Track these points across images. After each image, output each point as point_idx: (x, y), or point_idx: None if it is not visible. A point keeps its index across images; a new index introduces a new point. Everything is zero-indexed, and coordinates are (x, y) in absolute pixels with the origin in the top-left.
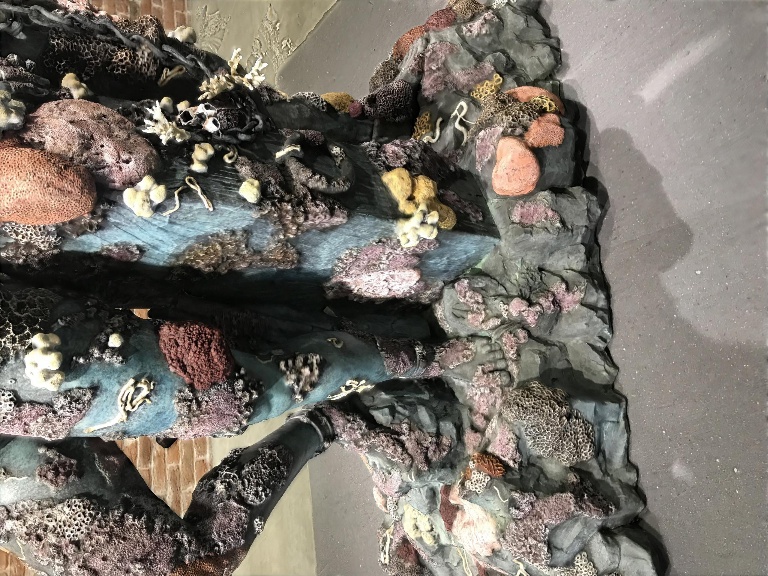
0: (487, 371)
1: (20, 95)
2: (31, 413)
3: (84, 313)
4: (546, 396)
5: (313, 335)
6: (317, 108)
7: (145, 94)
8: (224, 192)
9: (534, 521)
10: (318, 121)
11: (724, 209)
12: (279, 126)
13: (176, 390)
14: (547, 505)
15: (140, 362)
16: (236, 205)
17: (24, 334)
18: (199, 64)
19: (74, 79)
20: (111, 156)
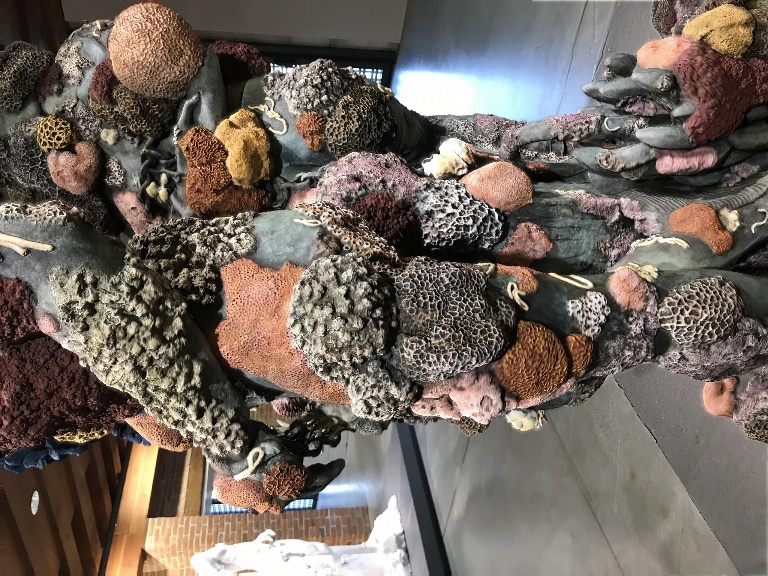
0: None
1: None
2: None
3: None
4: None
5: None
6: None
7: None
8: None
9: None
10: None
11: (723, 419)
12: None
13: None
14: None
15: None
16: None
17: None
18: None
19: None
20: None
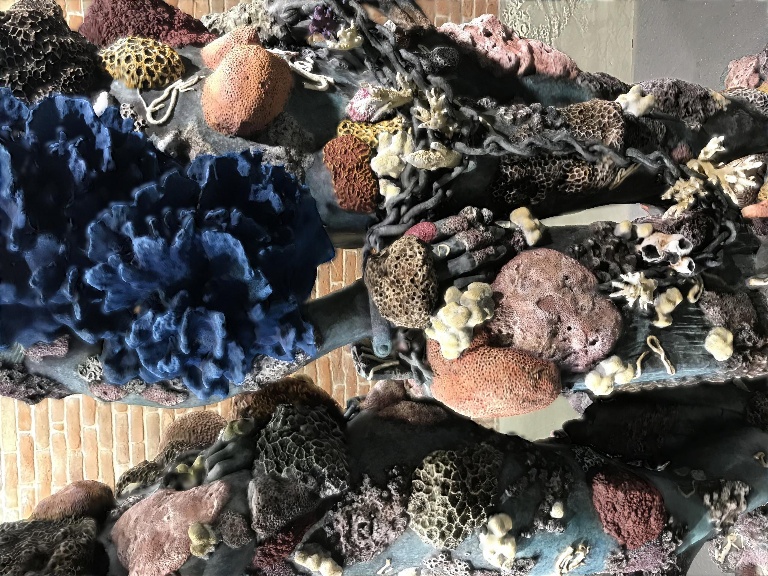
0: None
1: (482, 266)
2: (480, 575)
3: (526, 477)
4: None
5: (737, 448)
6: (763, 115)
7: (591, 199)
8: (688, 349)
9: None
10: (760, 132)
11: None
12: None
13: (609, 552)
14: None
15: (577, 527)
16: (701, 366)
17: (480, 515)
18: (665, 161)
19: (528, 218)
20: (579, 342)
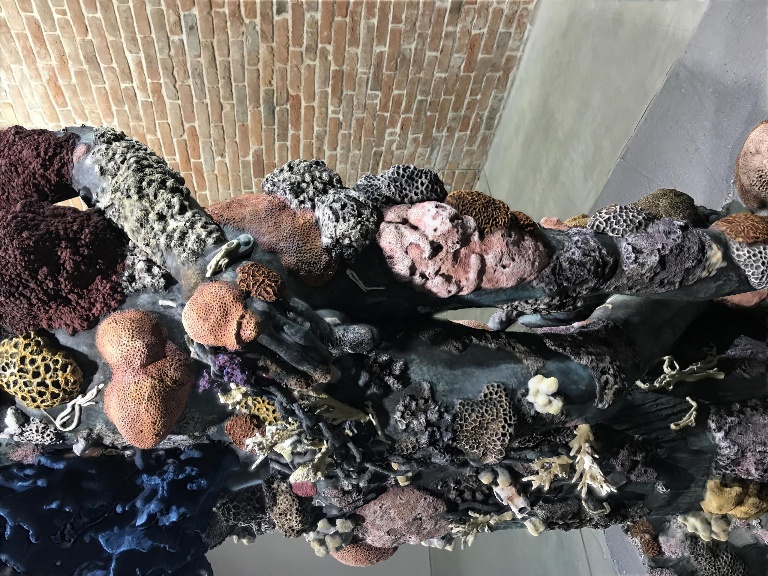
0: None
1: None
2: None
3: None
4: (723, 571)
5: None
6: None
7: None
8: None
9: (656, 569)
10: (741, 291)
11: None
12: None
13: None
14: (670, 575)
15: None
16: None
17: None
18: None
19: None
20: None
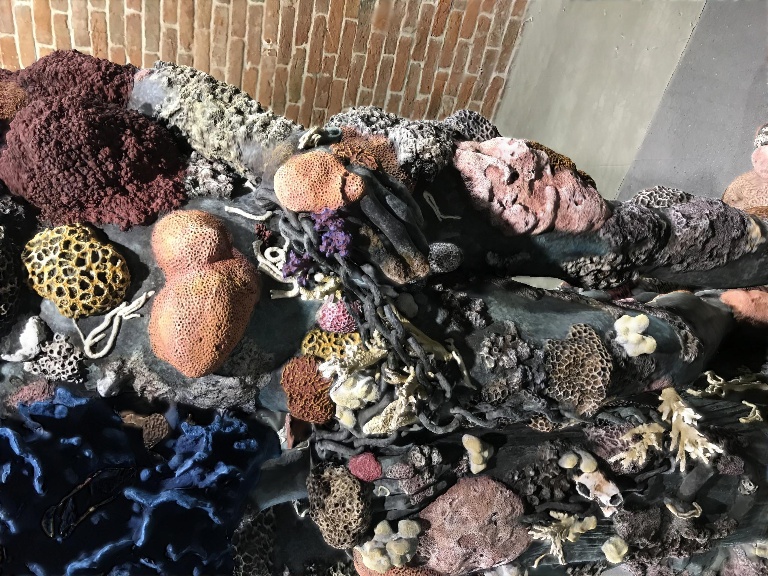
0: (766, 572)
1: None
2: None
3: None
4: None
5: None
6: None
7: None
8: (586, 550)
9: None
10: None
11: None
12: (717, 285)
13: None
14: None
15: None
16: None
17: None
18: (635, 415)
19: (478, 453)
20: (487, 566)
